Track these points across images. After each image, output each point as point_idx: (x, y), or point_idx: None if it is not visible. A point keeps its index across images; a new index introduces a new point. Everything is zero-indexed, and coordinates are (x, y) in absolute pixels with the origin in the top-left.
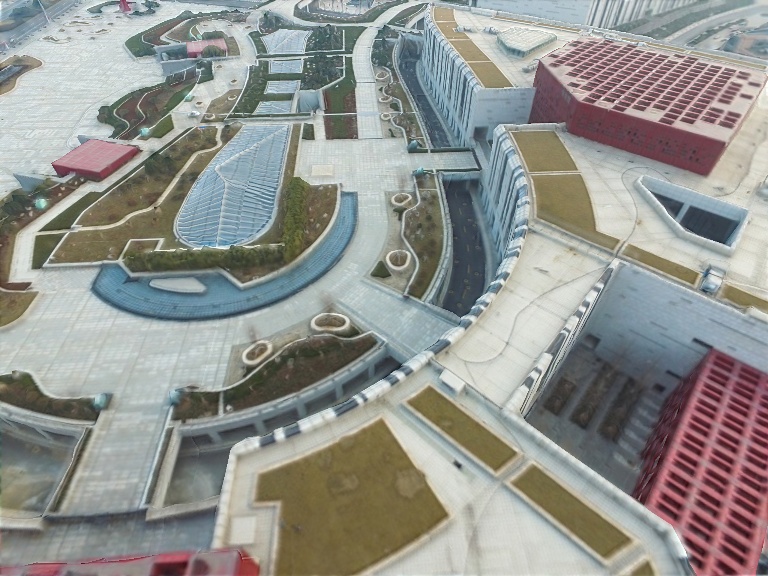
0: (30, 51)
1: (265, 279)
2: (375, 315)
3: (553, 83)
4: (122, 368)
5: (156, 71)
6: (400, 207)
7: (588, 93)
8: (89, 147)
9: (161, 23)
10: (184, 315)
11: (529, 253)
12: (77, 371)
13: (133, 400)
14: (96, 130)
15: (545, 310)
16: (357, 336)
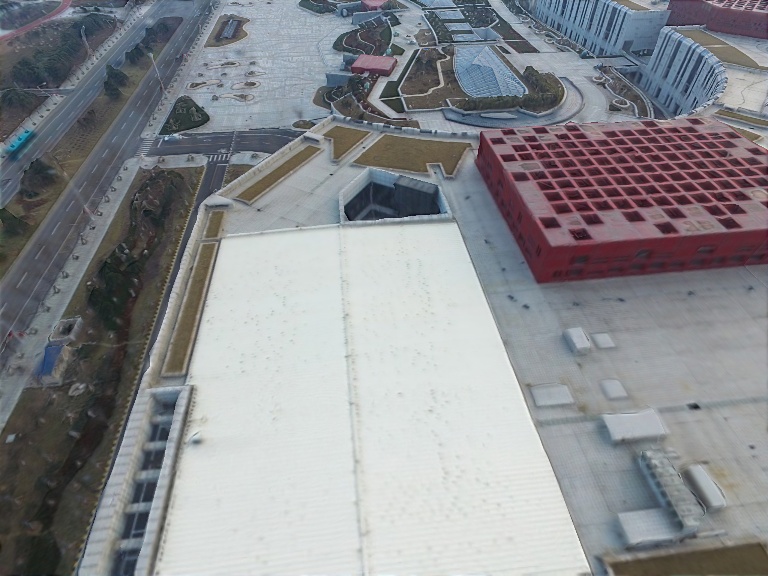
0: (230, 12)
1: (549, 112)
2: None
3: (692, 2)
4: None
5: (343, 22)
6: (601, 82)
7: (723, 3)
8: (366, 58)
9: None
10: None
11: (729, 74)
12: None
13: None
14: (339, 56)
15: (754, 91)
16: None
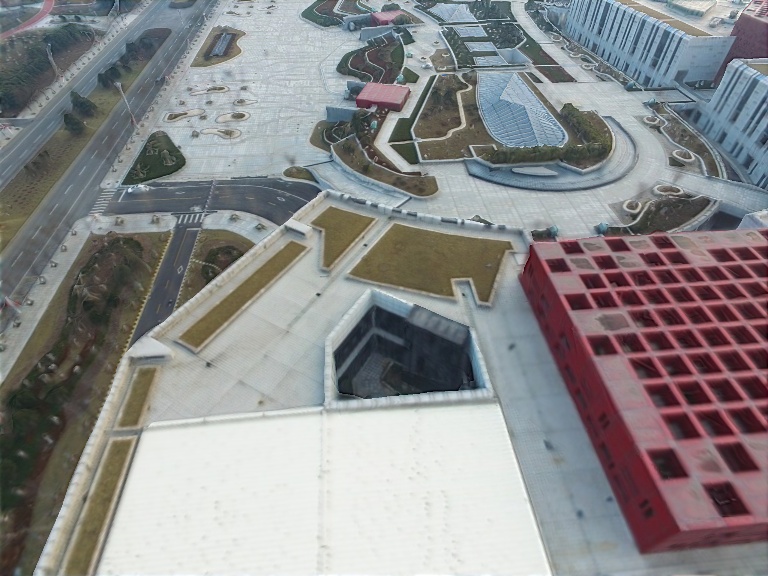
0: (225, 23)
1: (596, 167)
2: (695, 187)
3: (766, 28)
4: (542, 216)
5: (350, 38)
6: (654, 125)
7: None
8: (373, 87)
9: (318, 0)
10: (555, 188)
11: None
12: (512, 218)
13: (568, 232)
14: (343, 80)
15: None
16: (693, 198)
